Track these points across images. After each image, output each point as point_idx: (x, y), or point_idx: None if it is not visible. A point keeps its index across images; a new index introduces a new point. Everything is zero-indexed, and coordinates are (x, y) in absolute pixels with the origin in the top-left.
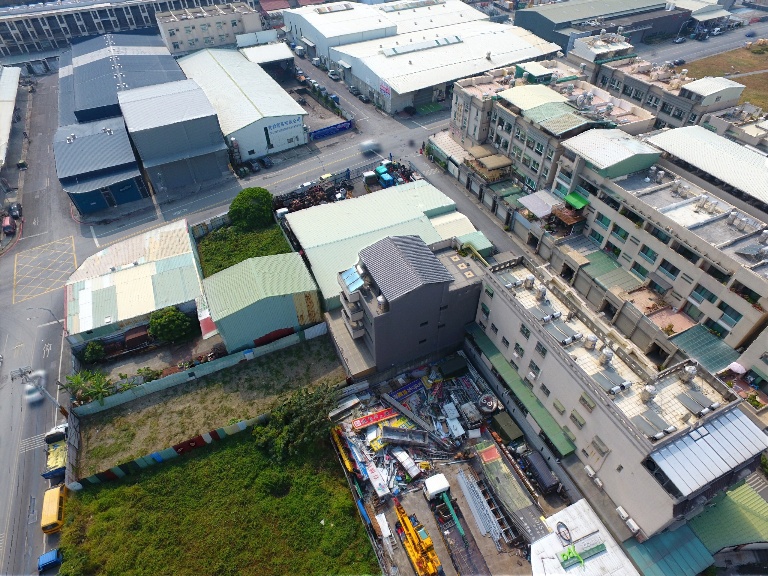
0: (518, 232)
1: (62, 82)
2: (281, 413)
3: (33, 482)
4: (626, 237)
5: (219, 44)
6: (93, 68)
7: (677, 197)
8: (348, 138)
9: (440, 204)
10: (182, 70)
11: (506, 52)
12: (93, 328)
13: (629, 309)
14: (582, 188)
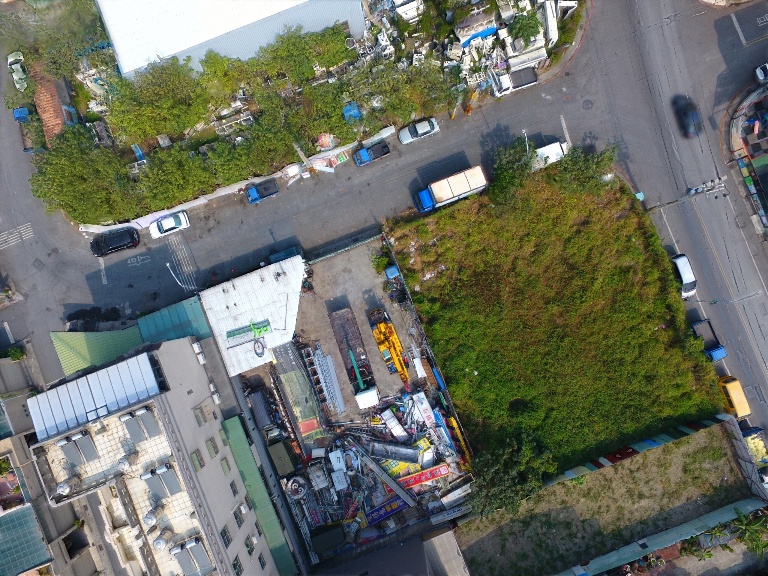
0: None
1: None
2: None
3: (767, 426)
4: None
5: None
6: None
7: None
8: None
9: None
10: None
11: None
12: None
13: None
14: None
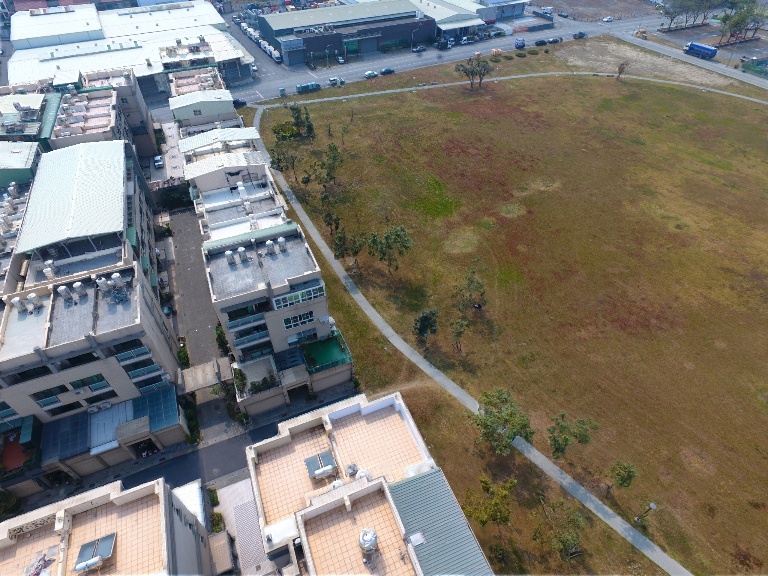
0: None
1: None
2: None
3: None
4: None
5: None
6: None
7: None
8: None
9: None
10: None
11: None
12: None
13: None
14: None
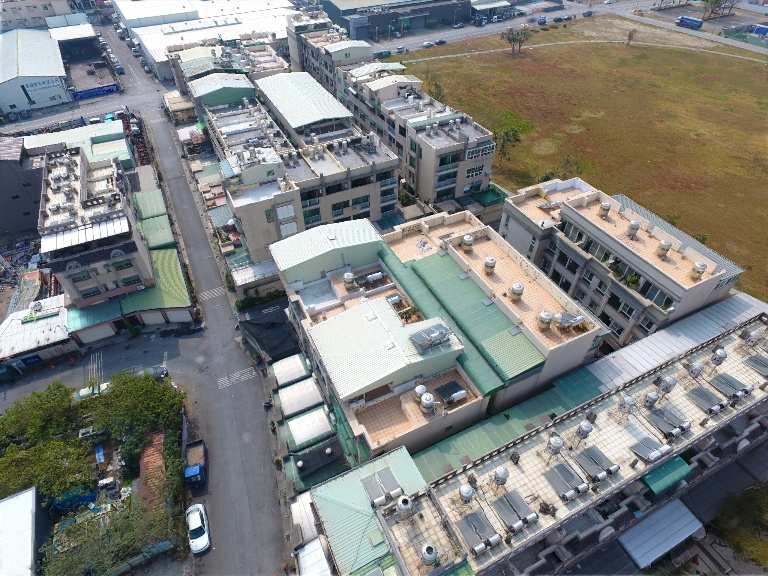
0: None
1: None
2: None
3: None
4: None
5: (33, 25)
6: None
7: (249, 117)
8: (111, 98)
9: (110, 133)
10: None
11: None
12: None
13: None
14: None
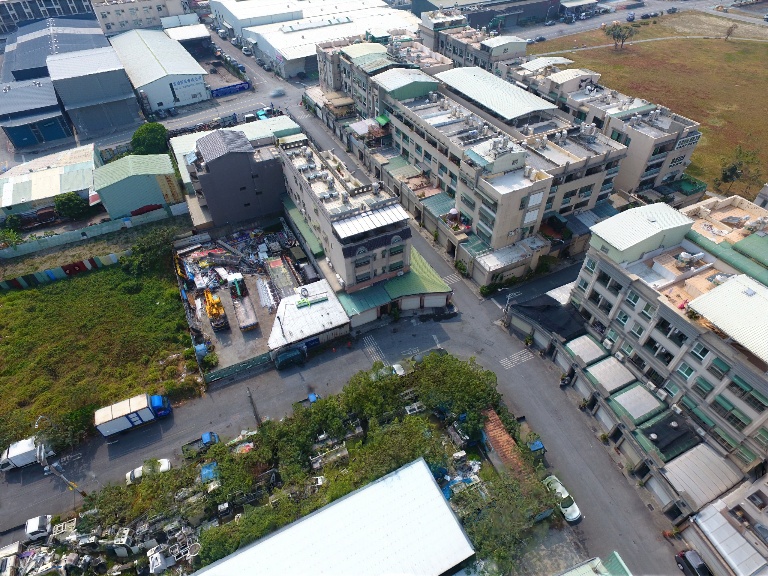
0: (355, 152)
1: (7, 55)
2: (139, 247)
3: None
4: (409, 140)
5: (147, 26)
6: (33, 43)
7: (442, 110)
8: (245, 95)
9: (288, 127)
10: (111, 45)
11: (387, 29)
12: (12, 205)
13: (403, 187)
14: (386, 110)
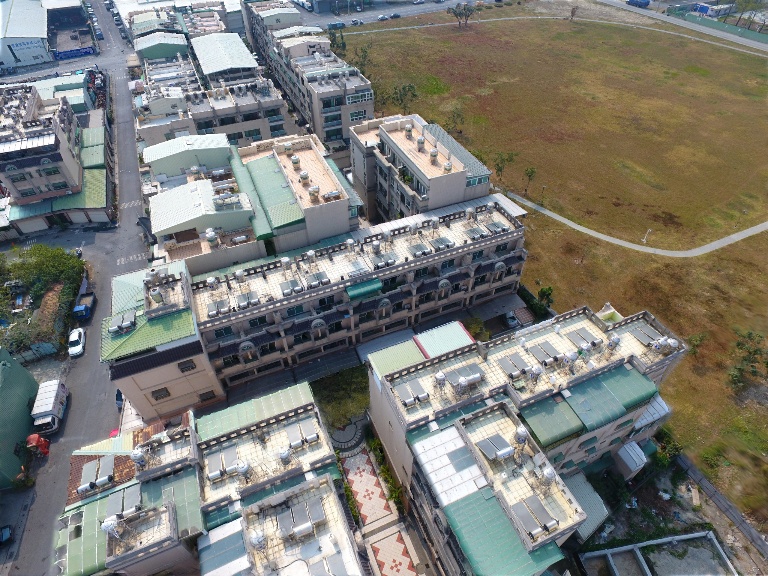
0: None
1: None
2: None
3: None
4: None
5: None
6: None
7: None
8: (87, 59)
9: (72, 82)
10: None
11: (238, 3)
12: None
13: None
14: None
